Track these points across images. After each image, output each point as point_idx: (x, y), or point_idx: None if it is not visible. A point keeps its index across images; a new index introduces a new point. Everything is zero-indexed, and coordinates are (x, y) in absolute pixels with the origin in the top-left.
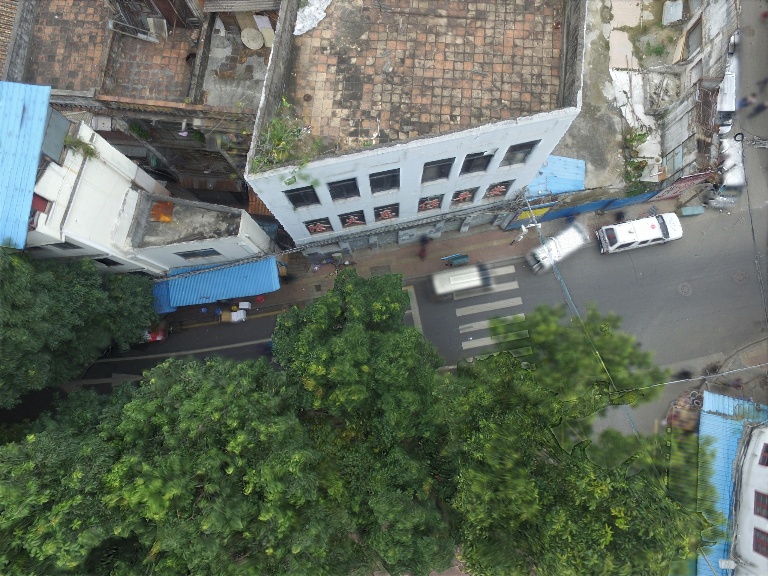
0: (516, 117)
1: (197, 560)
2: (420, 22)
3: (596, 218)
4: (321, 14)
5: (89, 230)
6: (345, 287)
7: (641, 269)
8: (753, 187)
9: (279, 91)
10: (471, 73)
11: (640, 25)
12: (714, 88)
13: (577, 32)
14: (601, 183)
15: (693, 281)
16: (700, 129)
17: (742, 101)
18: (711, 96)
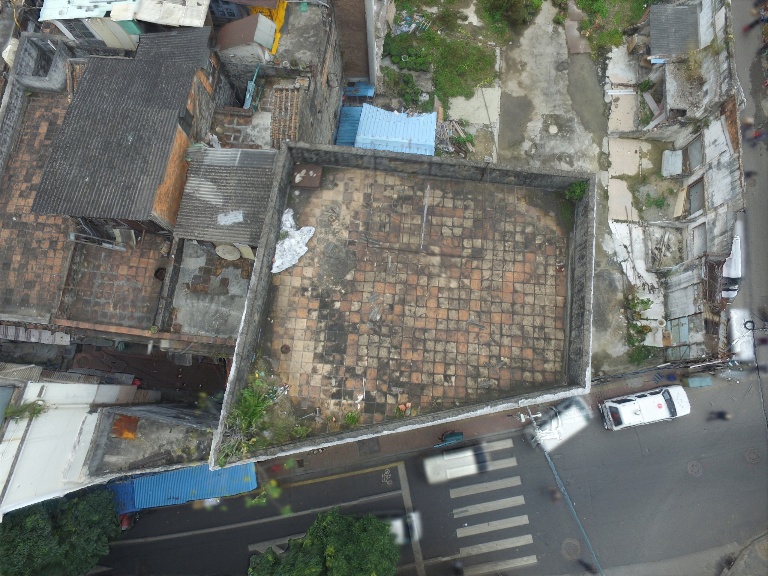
0: (518, 400)
1: None
2: (411, 261)
3: (598, 386)
4: (302, 248)
5: (35, 485)
6: (326, 547)
7: (647, 445)
8: (762, 353)
9: (253, 343)
10: (467, 324)
11: (639, 174)
12: (720, 260)
13: (584, 294)
14: (603, 346)
15: (703, 460)
16: (707, 306)
17: (746, 257)
18: (717, 268)
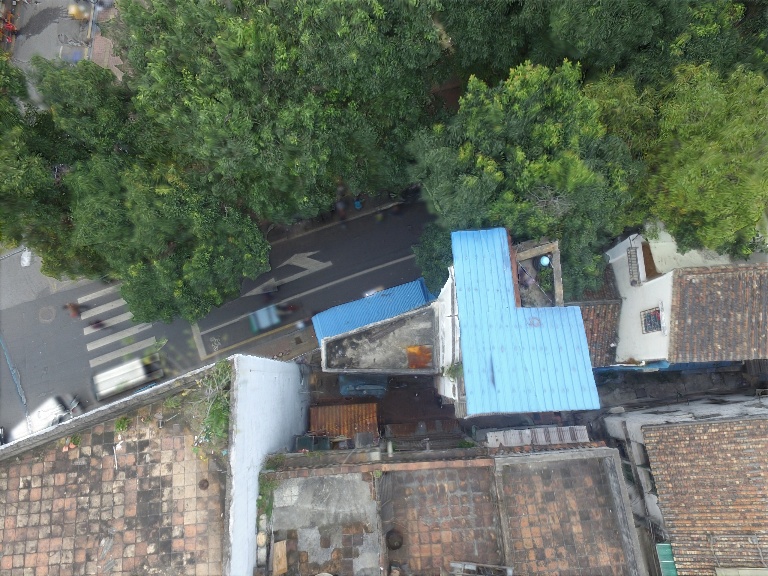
0: None
1: (188, 5)
2: None
3: None
4: None
5: None
6: None
7: None
8: None
9: None
10: (3, 553)
11: None
12: None
13: None
14: None
15: None
16: None
17: None
18: None
